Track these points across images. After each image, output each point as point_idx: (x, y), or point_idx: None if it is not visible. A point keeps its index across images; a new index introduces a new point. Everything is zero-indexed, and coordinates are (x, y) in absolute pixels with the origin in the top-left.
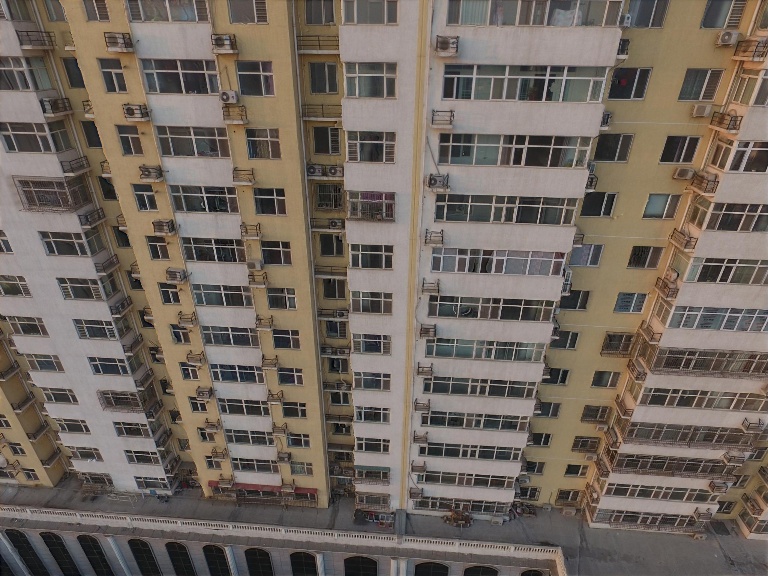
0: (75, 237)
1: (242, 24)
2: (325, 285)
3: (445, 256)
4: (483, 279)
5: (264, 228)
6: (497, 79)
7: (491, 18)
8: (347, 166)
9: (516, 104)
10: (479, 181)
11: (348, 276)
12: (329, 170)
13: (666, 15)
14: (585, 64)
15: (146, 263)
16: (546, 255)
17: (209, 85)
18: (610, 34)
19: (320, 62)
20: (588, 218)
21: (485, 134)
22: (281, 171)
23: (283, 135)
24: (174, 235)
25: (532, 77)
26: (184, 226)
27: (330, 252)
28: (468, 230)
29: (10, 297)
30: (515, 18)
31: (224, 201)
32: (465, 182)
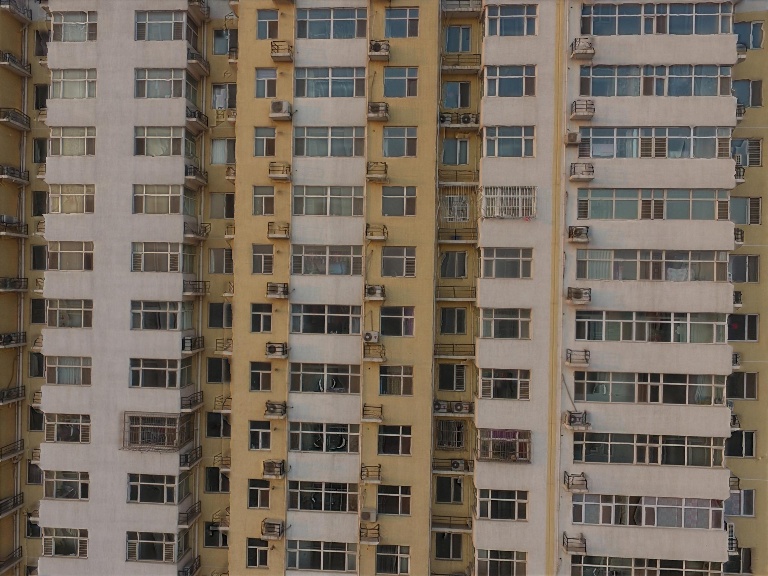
0: (167, 480)
1: (391, 277)
2: (437, 540)
3: (586, 504)
4: (634, 533)
5: (384, 470)
6: (625, 323)
7: (614, 274)
8: (480, 403)
9: (647, 345)
10: (618, 419)
11: (475, 529)
12: (455, 406)
13: (759, 273)
14: (706, 311)
15: (240, 512)
16: (701, 503)
17: (351, 326)
18: (723, 287)
19: (451, 307)
20: (730, 459)
21: (620, 372)
22: (411, 408)
23: (418, 372)
24: (283, 478)
25: (657, 321)
26: (295, 467)
27: (446, 498)
28: (611, 473)
29: (60, 558)
30: (636, 274)
31: (336, 439)
32: (604, 420)
